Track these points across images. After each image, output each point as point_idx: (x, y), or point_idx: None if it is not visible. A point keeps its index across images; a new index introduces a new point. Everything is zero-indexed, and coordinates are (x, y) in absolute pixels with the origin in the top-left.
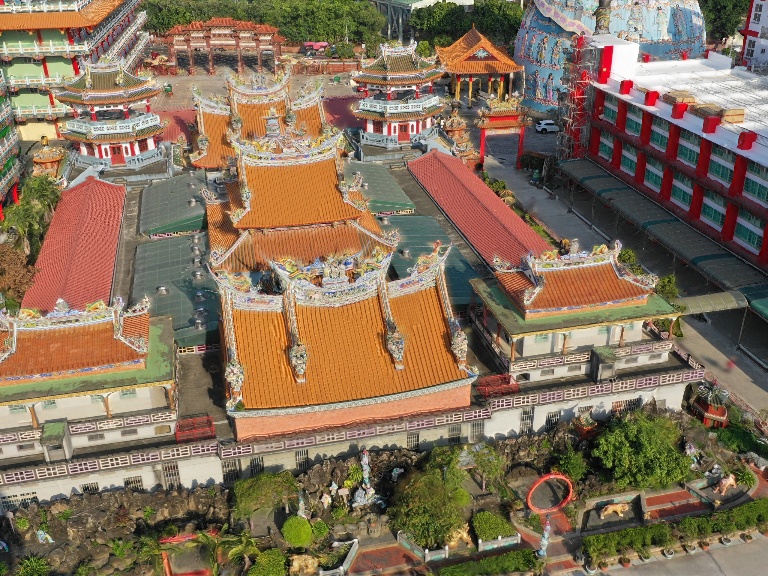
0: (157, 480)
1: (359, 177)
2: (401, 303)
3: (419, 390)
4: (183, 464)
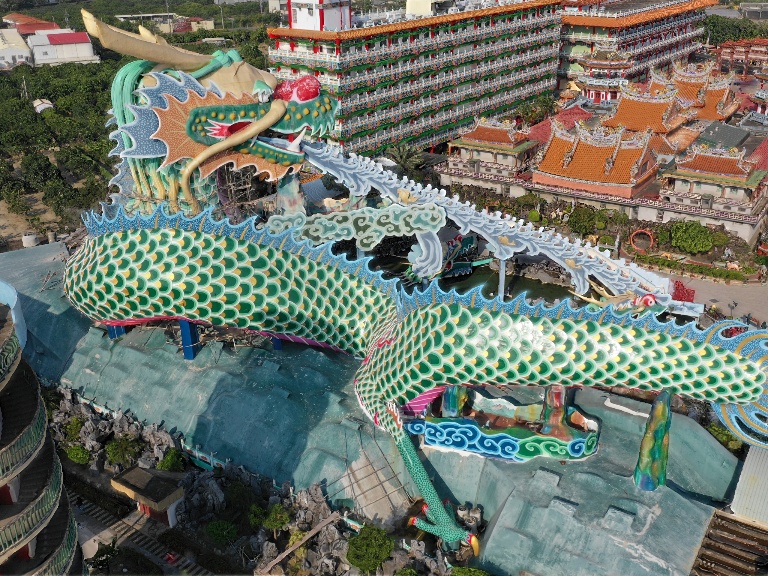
0: (502, 192)
1: (701, 124)
2: (625, 152)
3: (608, 183)
4: (512, 188)
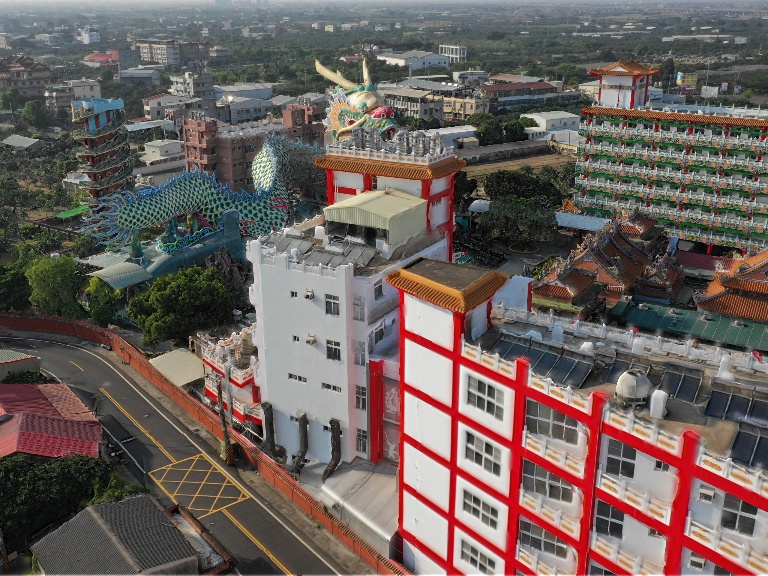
0: None
1: None
2: None
3: None
4: None
